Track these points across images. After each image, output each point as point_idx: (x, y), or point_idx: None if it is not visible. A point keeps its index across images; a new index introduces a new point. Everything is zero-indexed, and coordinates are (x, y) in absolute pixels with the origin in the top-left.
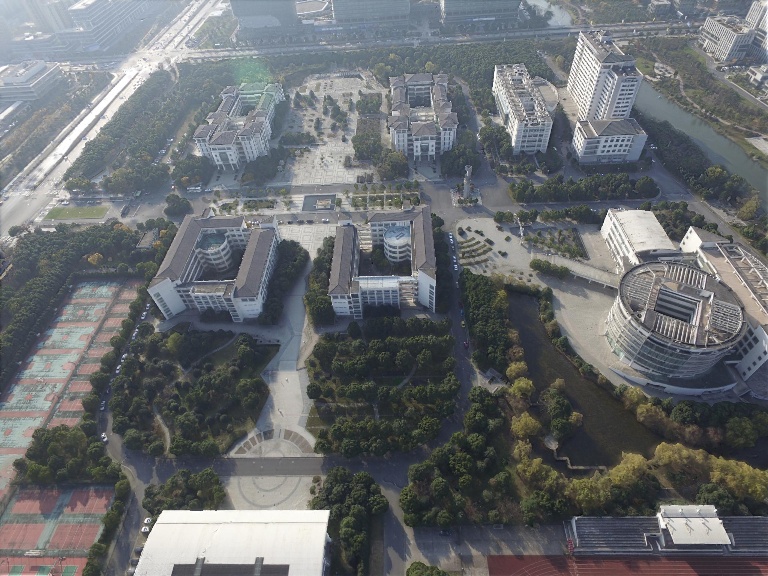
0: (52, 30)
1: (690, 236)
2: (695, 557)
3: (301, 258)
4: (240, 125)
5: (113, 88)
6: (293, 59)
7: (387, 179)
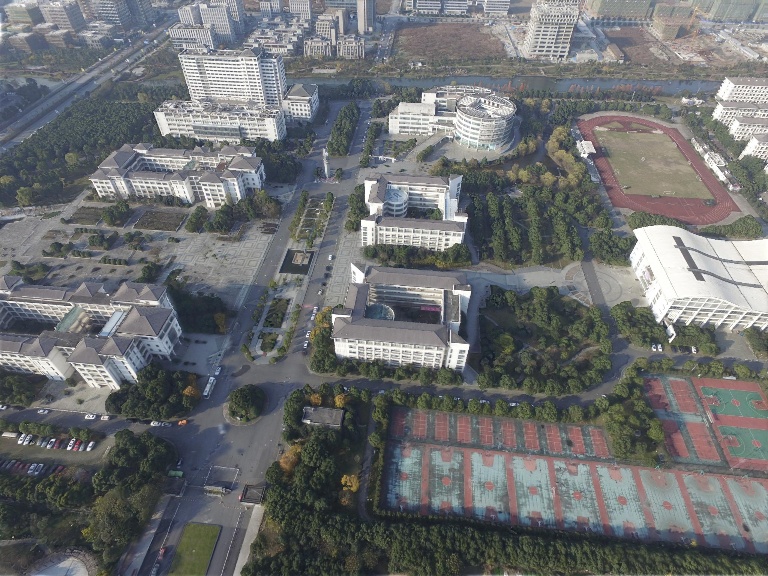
0: None
1: (426, 98)
2: (592, 157)
3: None
4: (76, 328)
5: None
6: None
7: (279, 214)
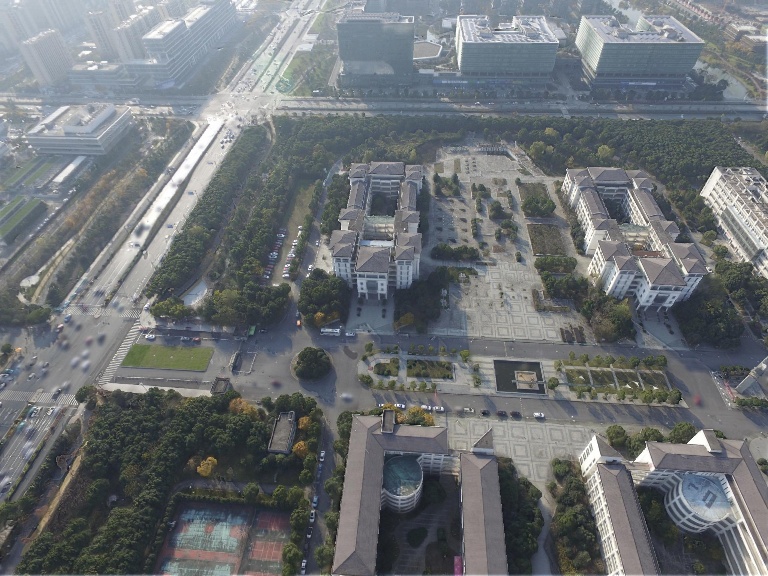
0: (119, 58)
1: None
2: None
3: (538, 511)
4: (380, 228)
5: (196, 144)
6: (420, 123)
7: (607, 340)
